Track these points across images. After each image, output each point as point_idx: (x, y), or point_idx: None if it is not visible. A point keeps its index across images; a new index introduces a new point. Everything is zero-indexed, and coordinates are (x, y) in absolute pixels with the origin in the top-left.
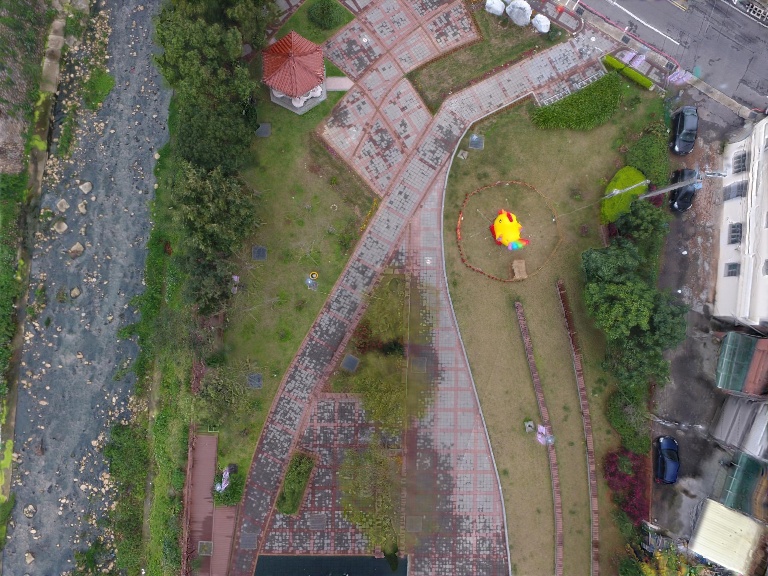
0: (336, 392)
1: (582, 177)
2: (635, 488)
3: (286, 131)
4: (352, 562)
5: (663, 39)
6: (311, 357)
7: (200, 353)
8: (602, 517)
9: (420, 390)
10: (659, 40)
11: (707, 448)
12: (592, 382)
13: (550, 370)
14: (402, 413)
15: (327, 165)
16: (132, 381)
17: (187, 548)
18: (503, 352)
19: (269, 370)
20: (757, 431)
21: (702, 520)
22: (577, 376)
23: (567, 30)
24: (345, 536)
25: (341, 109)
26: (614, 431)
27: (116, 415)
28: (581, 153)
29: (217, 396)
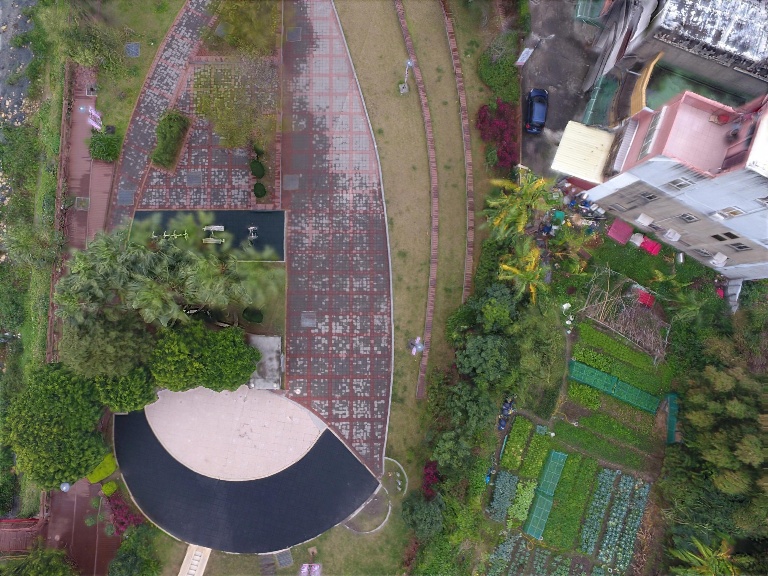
0: (211, 56)
1: None
2: (505, 133)
3: None
4: (228, 216)
5: None
6: (188, 27)
7: (72, 5)
8: (477, 170)
9: (295, 57)
10: None
11: (580, 104)
12: (464, 44)
13: (423, 34)
14: (278, 79)
15: None
16: (25, 85)
17: (65, 203)
18: (377, 20)
19: (146, 39)
20: (615, 51)
21: (564, 140)
22: (449, 38)
23: None
24: (221, 192)
25: None
26: (487, 89)
27: (9, 117)
28: None
29: (94, 61)
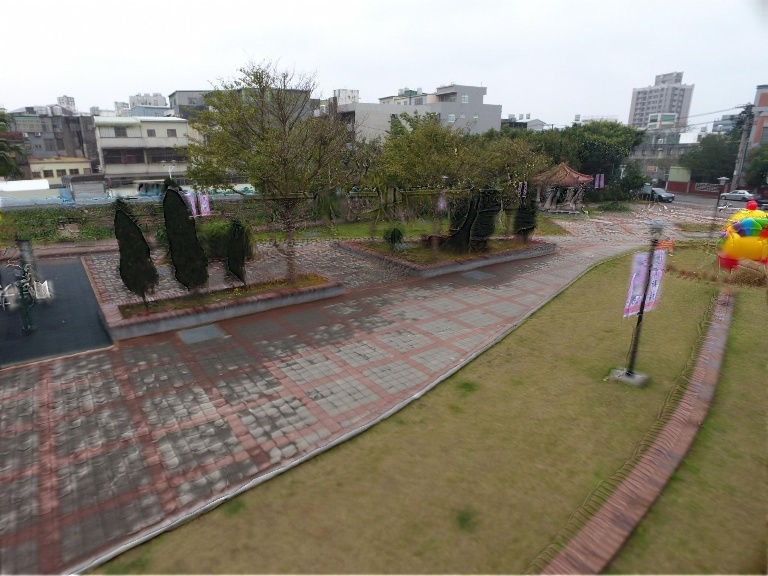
0: None
1: None
2: None
3: (528, 216)
4: (80, 300)
5: None
6: None
7: None
8: None
9: (451, 282)
10: None
11: None
12: None
13: (760, 350)
14: (398, 281)
15: (543, 224)
16: None
17: None
18: None
19: None
20: None
21: None
22: None
23: None
24: None
25: None
26: None
27: None
28: None
29: None
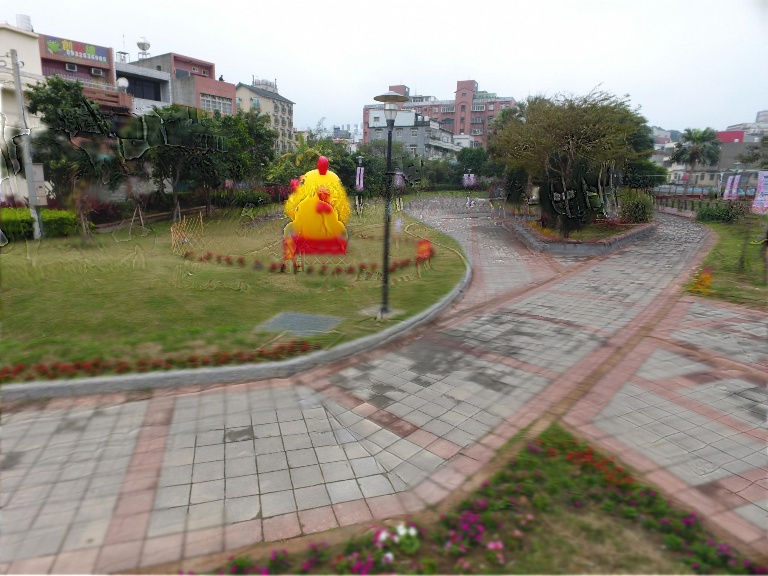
0: None
1: (30, 295)
2: None
3: None
4: None
5: None
6: None
7: None
8: None
9: None
10: None
11: None
12: None
13: None
14: None
15: None
16: None
17: None
18: None
19: None
20: None
21: None
22: None
23: None
24: None
25: None
26: None
27: None
28: None
29: None
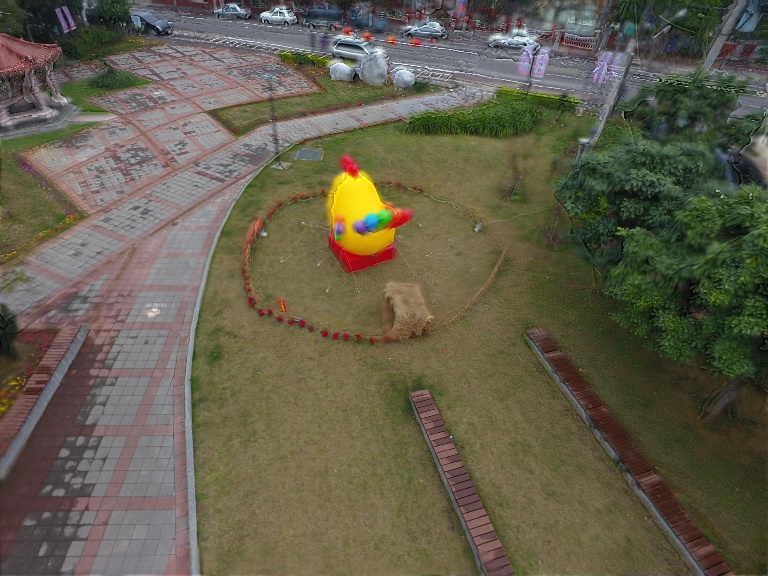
0: None
1: (513, 179)
2: None
3: None
4: None
5: (569, 92)
6: None
7: None
8: None
9: None
10: (565, 93)
11: None
12: None
13: None
14: None
15: None
16: None
17: None
18: None
19: None
20: None
21: None
22: None
23: (441, 88)
24: None
25: (78, 134)
26: None
27: None
28: (498, 155)
29: None
